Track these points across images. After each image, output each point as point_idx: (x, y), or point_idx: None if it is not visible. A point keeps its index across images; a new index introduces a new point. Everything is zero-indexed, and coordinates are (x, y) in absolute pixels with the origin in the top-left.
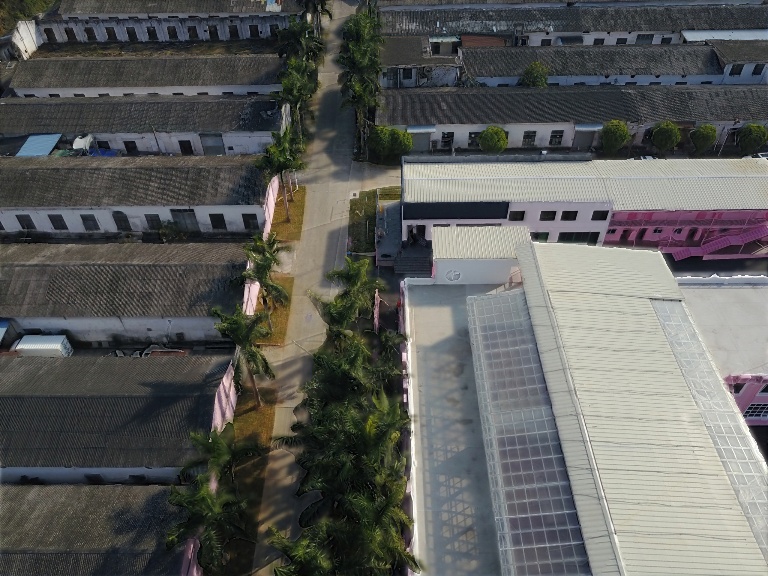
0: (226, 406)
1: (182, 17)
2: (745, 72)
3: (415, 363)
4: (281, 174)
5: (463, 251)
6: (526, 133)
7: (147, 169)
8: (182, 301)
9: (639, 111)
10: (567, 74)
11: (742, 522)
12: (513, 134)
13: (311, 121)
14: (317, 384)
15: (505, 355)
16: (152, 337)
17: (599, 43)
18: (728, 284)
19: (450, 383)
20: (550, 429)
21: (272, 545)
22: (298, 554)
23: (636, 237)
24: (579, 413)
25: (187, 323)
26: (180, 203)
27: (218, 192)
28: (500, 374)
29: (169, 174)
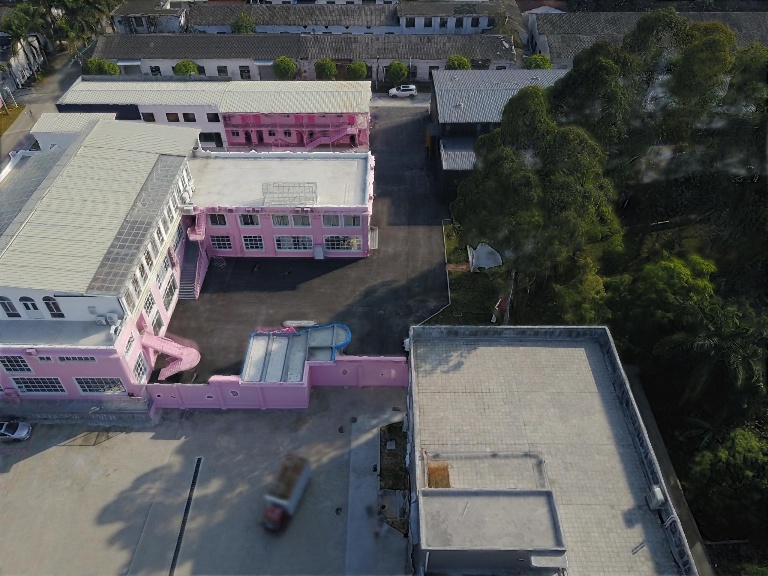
0: None
1: None
2: (418, 25)
3: None
4: None
5: (55, 128)
6: (219, 68)
7: None
8: None
9: (309, 51)
10: (271, 24)
11: (95, 264)
12: (209, 69)
13: (61, 61)
14: None
15: (25, 184)
16: None
17: None
18: (264, 158)
19: None
20: None
21: None
22: None
23: (258, 140)
24: (34, 208)
25: None
26: None
27: None
28: (13, 194)
29: None
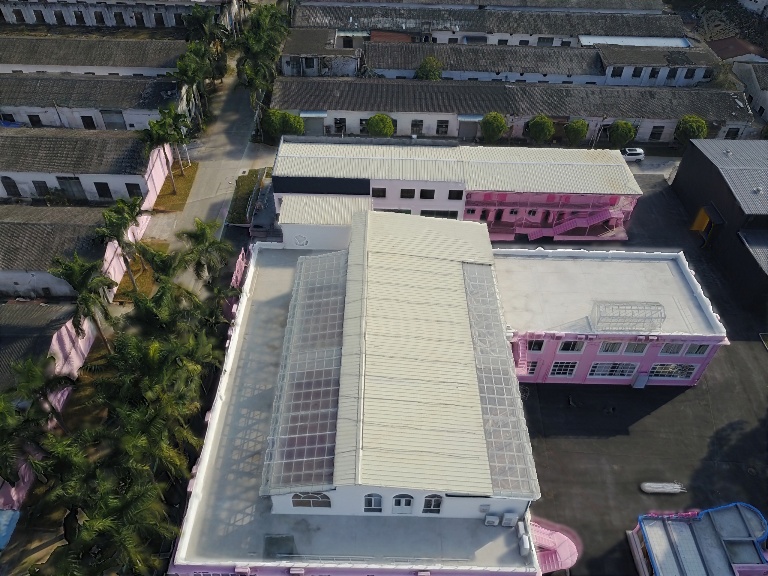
0: (70, 350)
1: (110, 3)
2: (625, 74)
3: (247, 315)
4: (163, 147)
5: (307, 217)
6: (414, 122)
7: (38, 138)
8: (46, 257)
9: (518, 105)
10: (460, 69)
11: (481, 444)
12: (402, 122)
13: (217, 104)
14: (124, 319)
15: (317, 305)
16: (20, 291)
17: (503, 44)
18: (552, 256)
19: (274, 332)
20: (336, 366)
21: (43, 447)
22: (56, 451)
23: (495, 218)
24: (362, 352)
25: (51, 278)
26: (65, 171)
27: (103, 162)
28: (308, 321)
29: (58, 144)
